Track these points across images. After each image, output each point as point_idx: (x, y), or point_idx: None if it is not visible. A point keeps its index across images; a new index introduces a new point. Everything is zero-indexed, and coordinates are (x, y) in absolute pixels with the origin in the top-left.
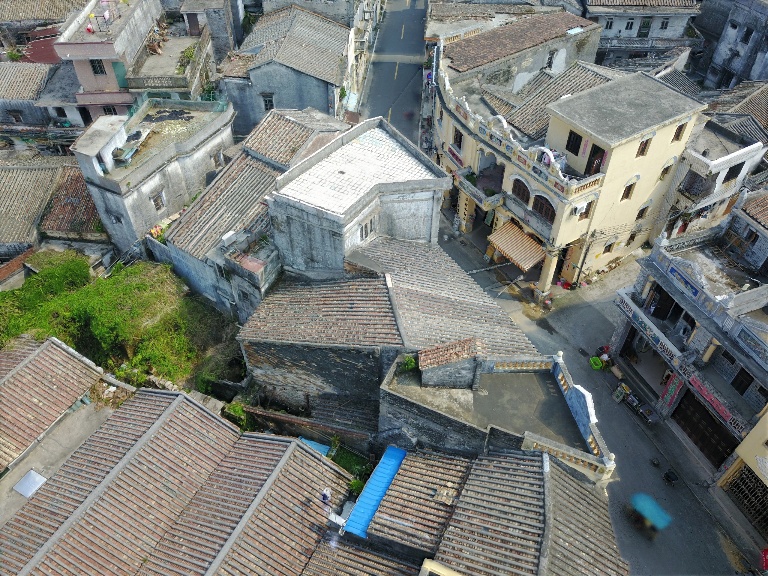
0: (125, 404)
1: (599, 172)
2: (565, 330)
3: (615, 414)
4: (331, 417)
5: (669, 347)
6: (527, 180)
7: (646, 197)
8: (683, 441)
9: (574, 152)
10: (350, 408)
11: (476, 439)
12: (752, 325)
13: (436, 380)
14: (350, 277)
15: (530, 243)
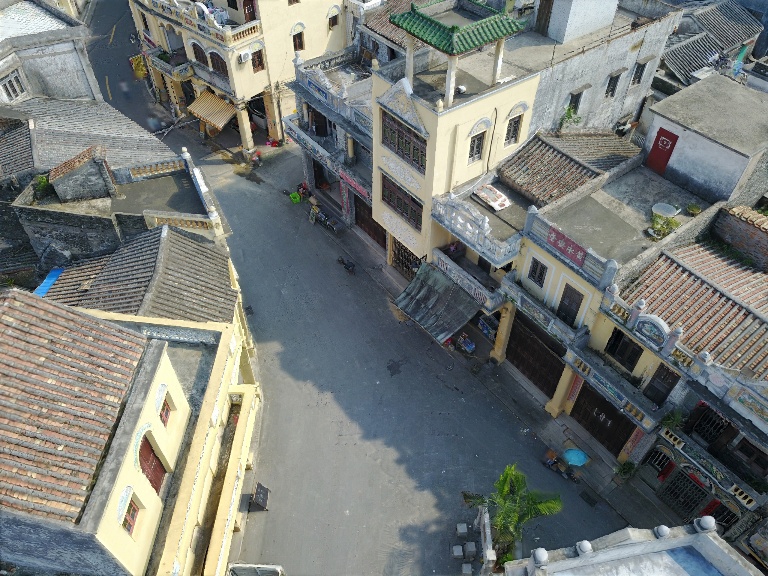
0: None
1: (255, 19)
2: (272, 179)
3: (310, 233)
4: (4, 265)
5: (320, 151)
6: (199, 40)
7: (324, 49)
8: (365, 240)
9: (234, 7)
10: (22, 253)
11: (107, 230)
12: (358, 105)
13: (72, 192)
14: (2, 134)
15: (223, 104)
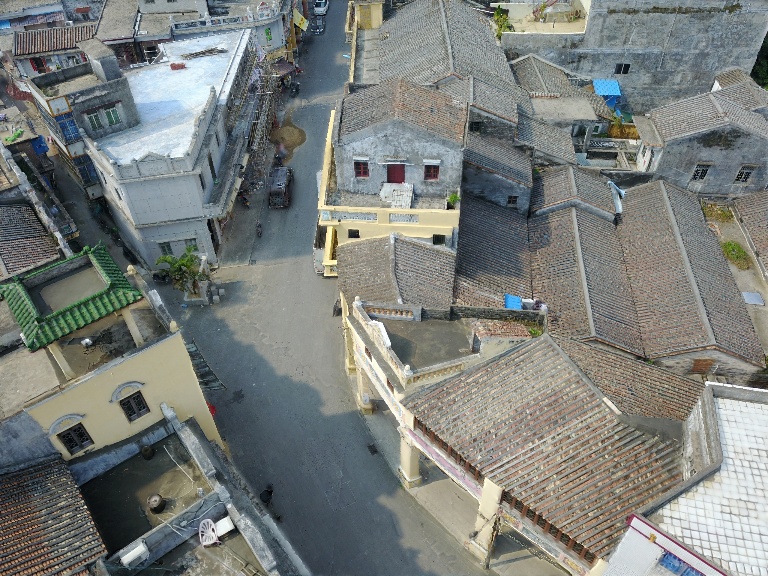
0: (760, 352)
1: None
2: None
3: (315, 570)
4: None
5: (275, 526)
6: None
7: None
8: None
9: None
10: None
11: None
12: None
13: None
14: None
15: None
